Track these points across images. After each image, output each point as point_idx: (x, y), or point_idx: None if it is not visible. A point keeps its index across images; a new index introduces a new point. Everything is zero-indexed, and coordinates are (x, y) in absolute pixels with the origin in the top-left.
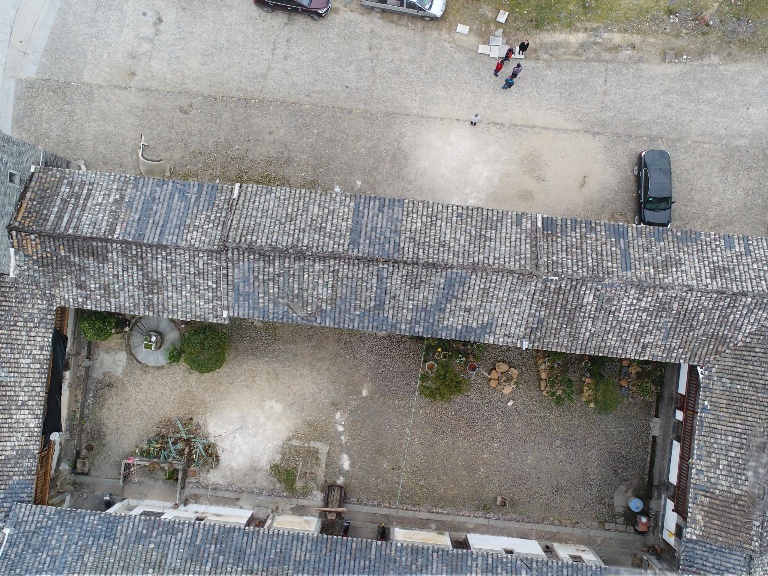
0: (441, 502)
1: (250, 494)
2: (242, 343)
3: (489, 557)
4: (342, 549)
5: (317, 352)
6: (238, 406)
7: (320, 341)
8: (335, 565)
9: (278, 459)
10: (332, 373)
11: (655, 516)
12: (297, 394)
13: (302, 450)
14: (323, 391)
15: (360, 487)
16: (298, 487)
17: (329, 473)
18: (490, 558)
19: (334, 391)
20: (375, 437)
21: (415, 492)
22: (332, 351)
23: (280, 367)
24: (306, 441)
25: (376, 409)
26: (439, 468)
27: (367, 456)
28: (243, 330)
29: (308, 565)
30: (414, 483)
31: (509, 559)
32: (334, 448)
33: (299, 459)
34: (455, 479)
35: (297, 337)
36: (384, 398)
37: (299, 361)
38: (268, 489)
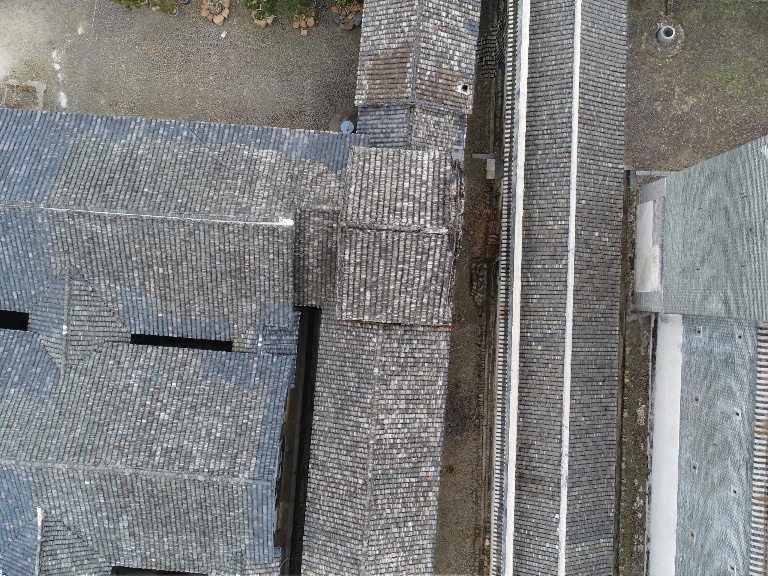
0: None
1: None
2: None
3: (152, 121)
4: (6, 118)
5: None
6: None
7: None
8: None
9: None
10: (47, 12)
11: None
12: (13, 34)
13: (20, 90)
14: (39, 30)
15: None
16: None
17: None
18: (153, 122)
19: (50, 30)
20: (92, 74)
21: None
22: None
23: None
24: (23, 81)
25: (92, 47)
26: (156, 103)
27: (84, 94)
28: None
29: None
30: None
31: (172, 123)
32: (51, 87)
33: (17, 99)
34: (172, 113)
35: None
36: (99, 35)
37: (15, 2)
38: None
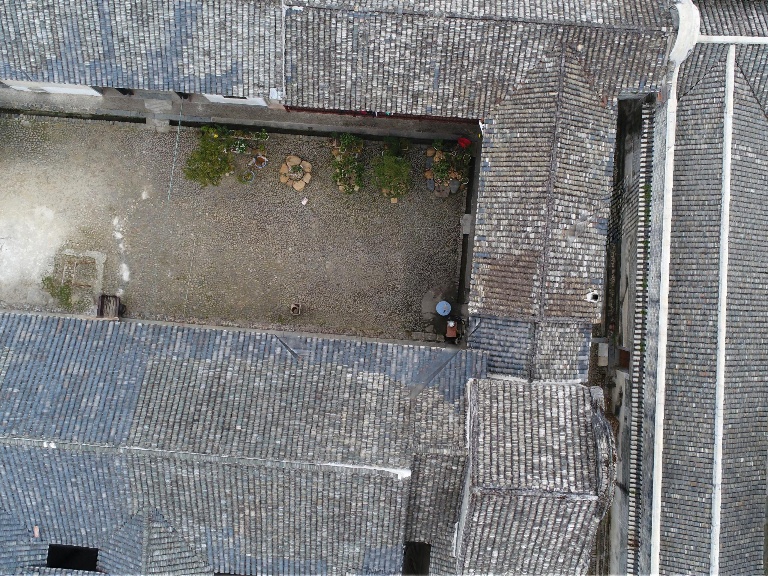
0: (231, 314)
1: (20, 310)
2: (8, 144)
3: (241, 335)
4: (74, 330)
5: (91, 152)
6: (5, 214)
7: (94, 140)
8: (63, 346)
9: (51, 271)
10: (108, 175)
11: (468, 322)
12: (70, 199)
13: (77, 261)
14: (99, 195)
15: (142, 300)
16: (73, 302)
17: (107, 285)
18: (242, 336)
19: (111, 195)
20: (157, 244)
21: (202, 304)
22: (108, 150)
23: (51, 170)
24: (81, 251)
25: (157, 213)
26: (229, 277)
27: (149, 265)
28: (9, 130)
29: (32, 346)
30: (201, 294)
31: (263, 337)
32: (112, 258)
33: None
34: (246, 288)
35: (69, 136)
36: (166, 201)
37: (71, 163)
38: (40, 305)
